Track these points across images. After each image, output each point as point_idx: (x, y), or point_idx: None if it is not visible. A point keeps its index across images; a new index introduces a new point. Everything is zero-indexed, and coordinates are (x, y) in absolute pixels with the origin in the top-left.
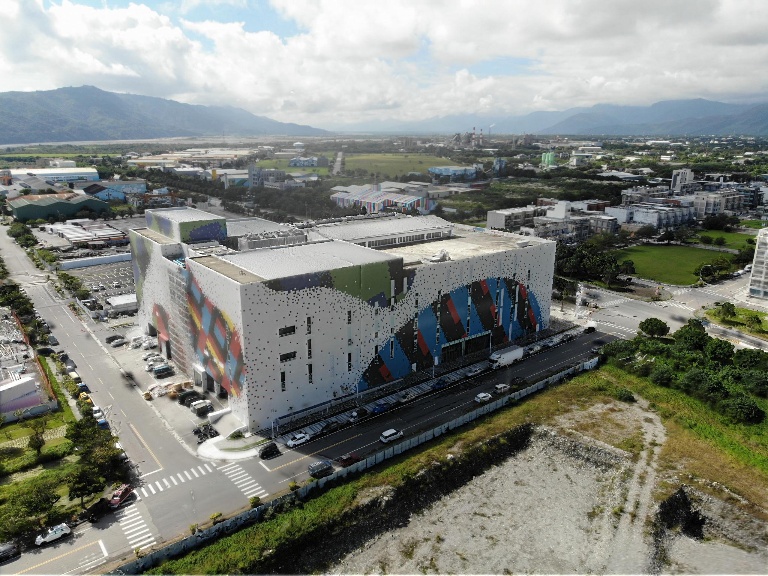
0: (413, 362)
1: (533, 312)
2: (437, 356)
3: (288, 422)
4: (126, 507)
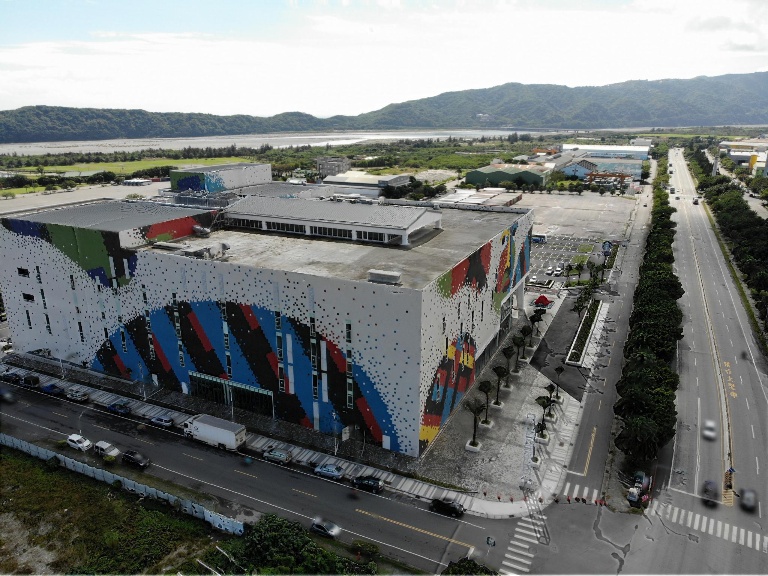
0: (154, 371)
1: (371, 407)
2: (186, 382)
3: (30, 358)
4: None
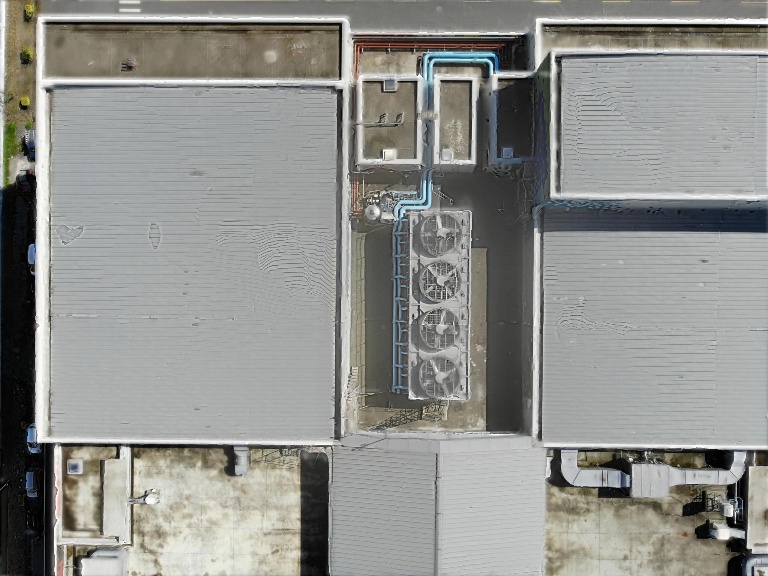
0: None
1: None
2: None
3: None
4: None
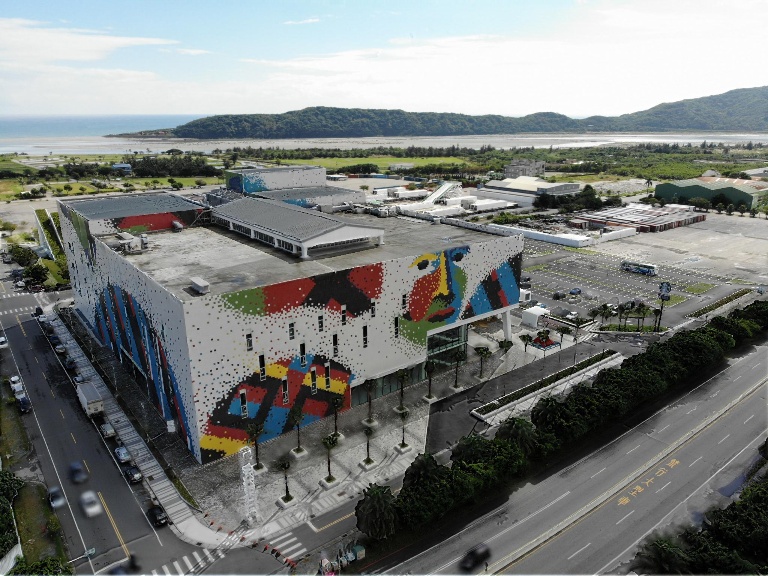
0: None
1: None
2: None
3: None
4: (29, 292)
